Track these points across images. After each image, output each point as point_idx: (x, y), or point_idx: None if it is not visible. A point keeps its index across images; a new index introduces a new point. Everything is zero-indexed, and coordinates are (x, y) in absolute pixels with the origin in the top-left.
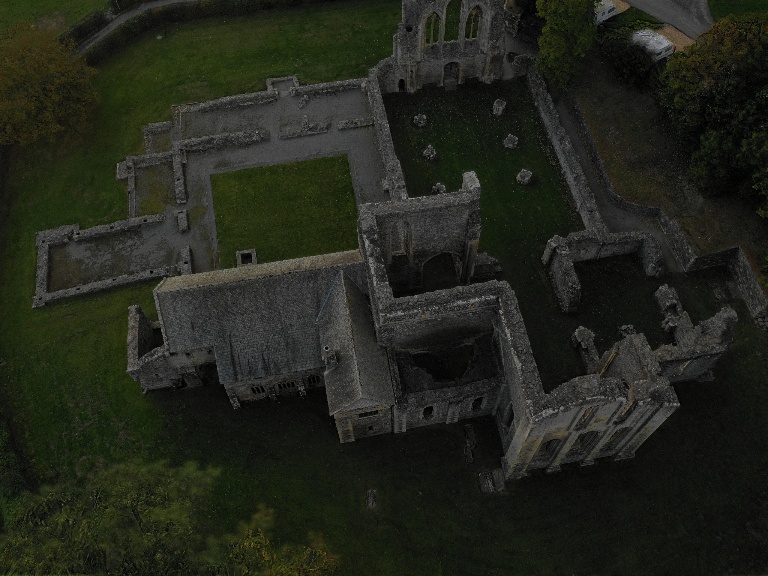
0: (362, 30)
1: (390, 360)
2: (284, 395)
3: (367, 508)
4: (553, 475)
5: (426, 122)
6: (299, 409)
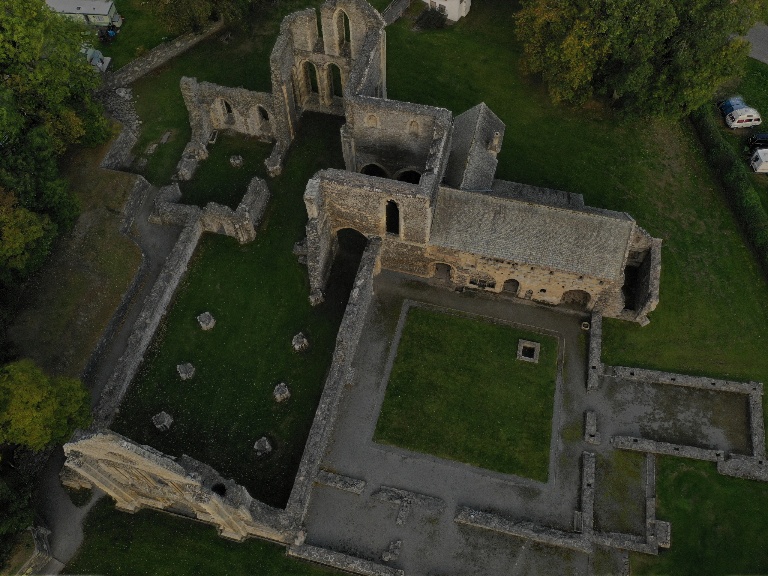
0: None
1: None
2: None
3: None
4: None
5: None
6: None
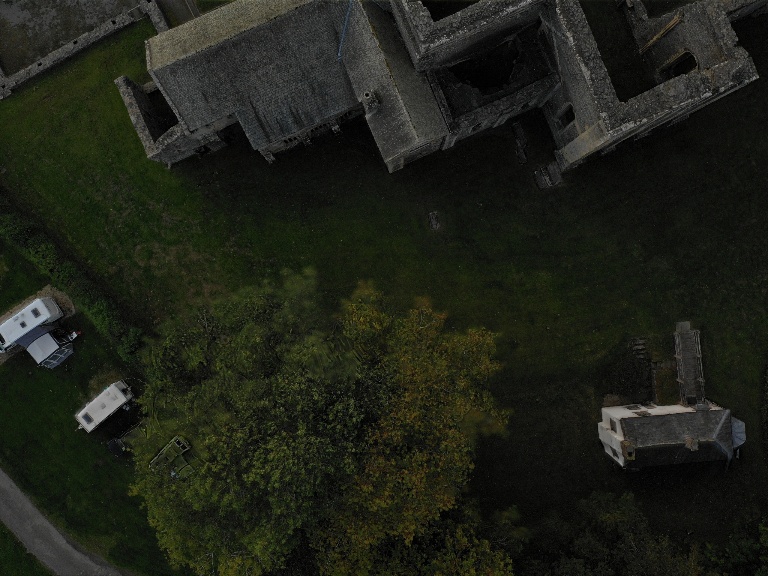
0: None
1: (432, 85)
2: (317, 136)
3: (432, 230)
4: (608, 156)
5: None
6: (337, 147)
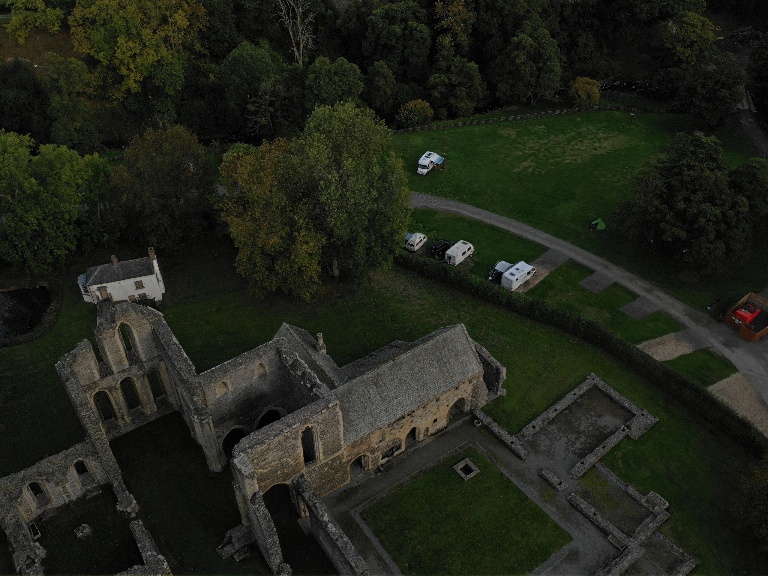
0: None
1: None
2: None
3: None
4: None
5: None
6: None
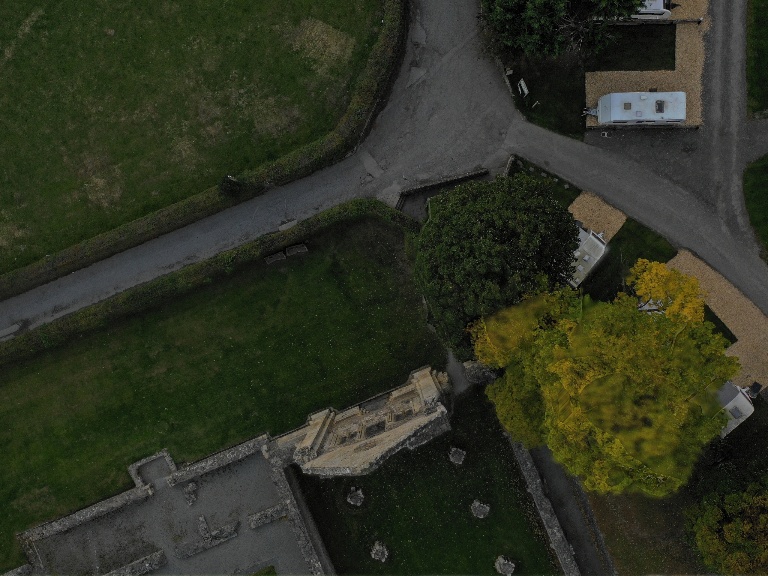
0: (235, 346)
1: None
2: None
3: None
4: None
5: (364, 497)
6: None
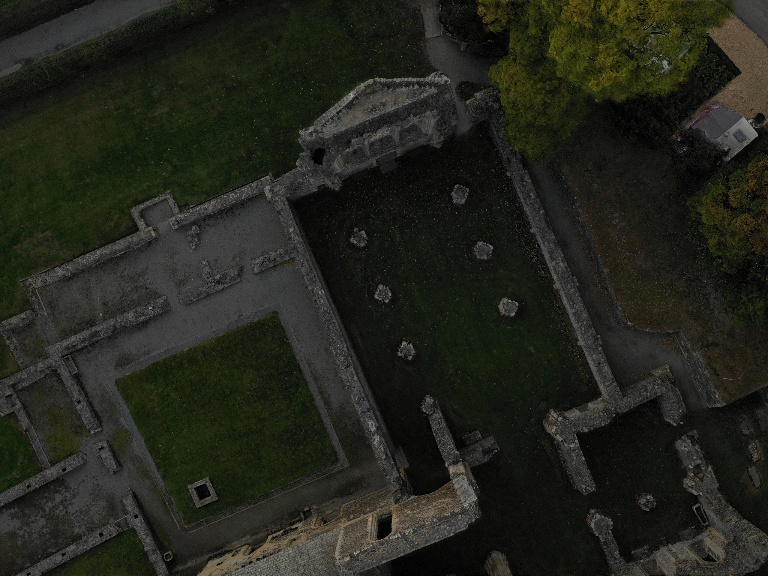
0: (237, 84)
1: None
2: None
3: None
4: None
5: (367, 239)
6: None
